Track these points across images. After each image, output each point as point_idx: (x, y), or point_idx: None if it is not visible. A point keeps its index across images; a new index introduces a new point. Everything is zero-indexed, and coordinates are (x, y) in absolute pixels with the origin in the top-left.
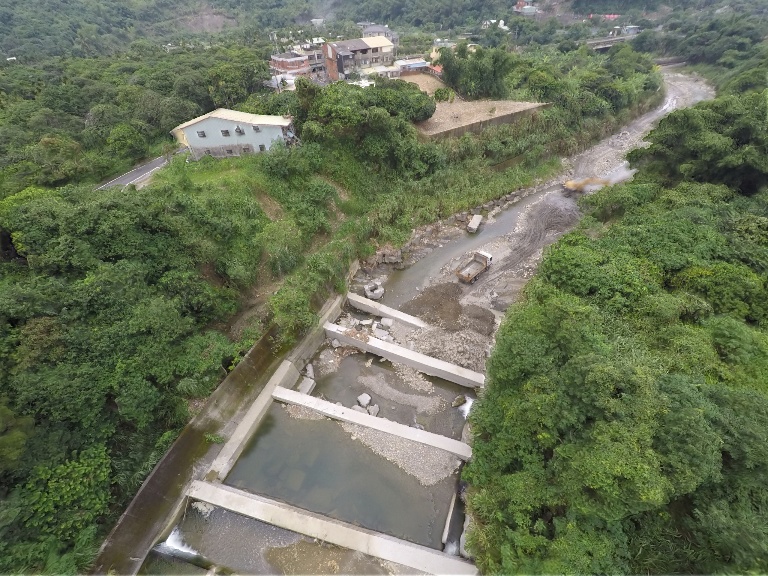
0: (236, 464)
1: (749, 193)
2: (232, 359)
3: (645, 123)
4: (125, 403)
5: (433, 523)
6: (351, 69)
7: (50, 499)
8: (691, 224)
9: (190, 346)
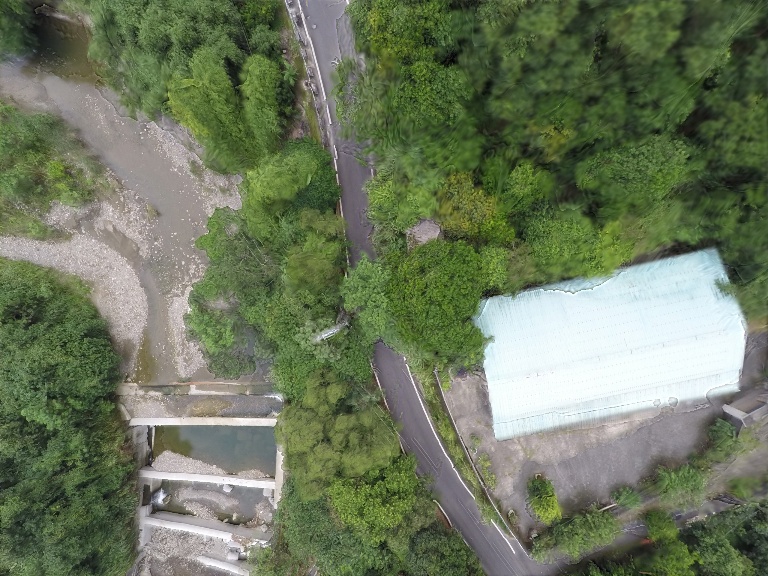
0: None
1: None
2: None
3: None
4: None
5: (162, 433)
6: None
7: None
8: None
9: None
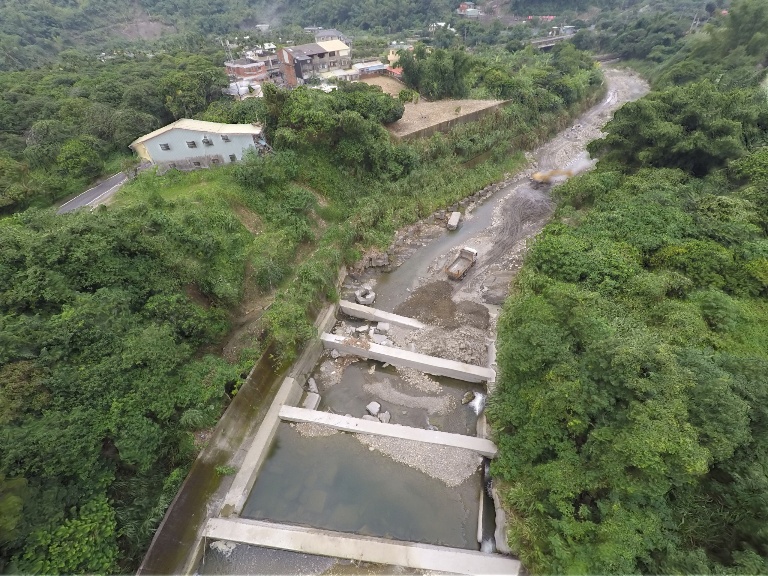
0: (250, 494)
1: (700, 175)
2: (234, 383)
3: (593, 116)
4: (127, 446)
5: (465, 524)
6: (310, 74)
7: (54, 567)
8: (660, 206)
9: (189, 374)
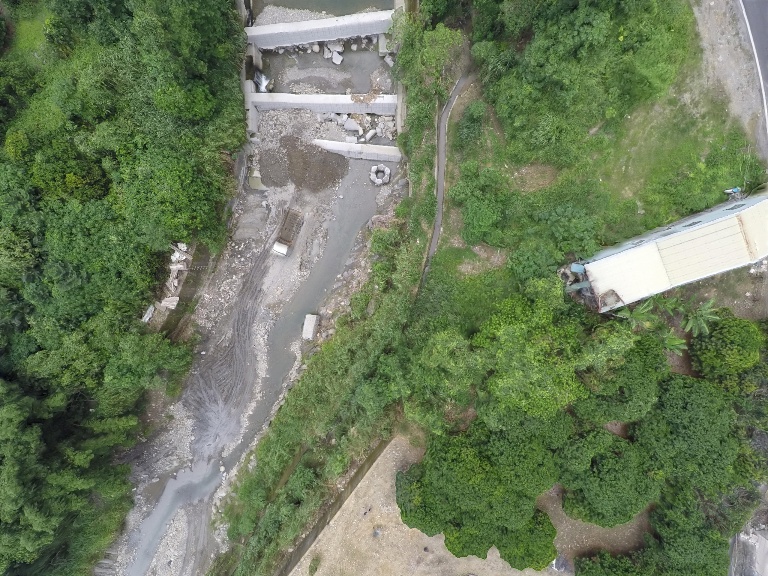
0: None
1: None
2: None
3: None
4: None
5: None
6: None
7: None
8: None
9: None
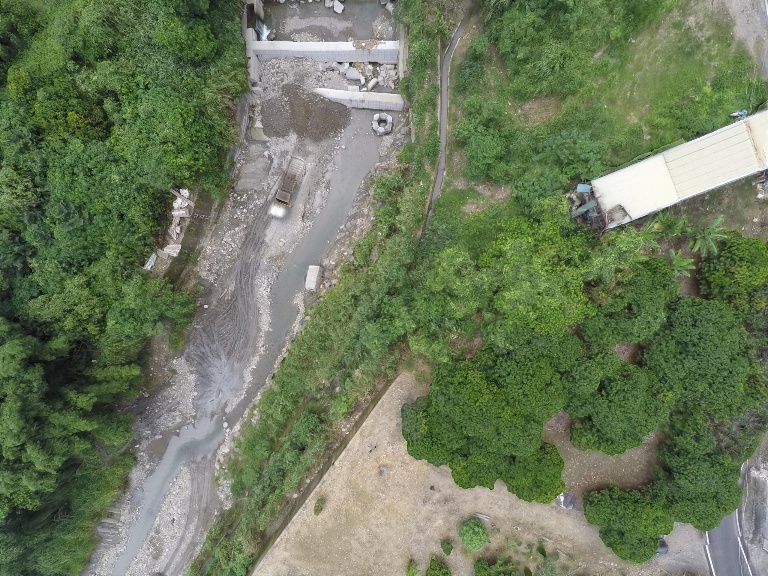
0: None
1: None
2: None
3: None
4: None
5: None
6: None
7: None
8: None
9: None
